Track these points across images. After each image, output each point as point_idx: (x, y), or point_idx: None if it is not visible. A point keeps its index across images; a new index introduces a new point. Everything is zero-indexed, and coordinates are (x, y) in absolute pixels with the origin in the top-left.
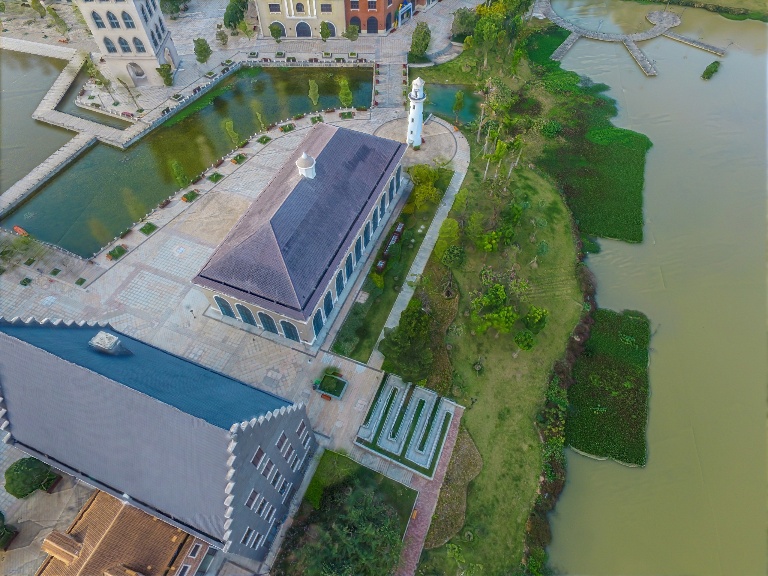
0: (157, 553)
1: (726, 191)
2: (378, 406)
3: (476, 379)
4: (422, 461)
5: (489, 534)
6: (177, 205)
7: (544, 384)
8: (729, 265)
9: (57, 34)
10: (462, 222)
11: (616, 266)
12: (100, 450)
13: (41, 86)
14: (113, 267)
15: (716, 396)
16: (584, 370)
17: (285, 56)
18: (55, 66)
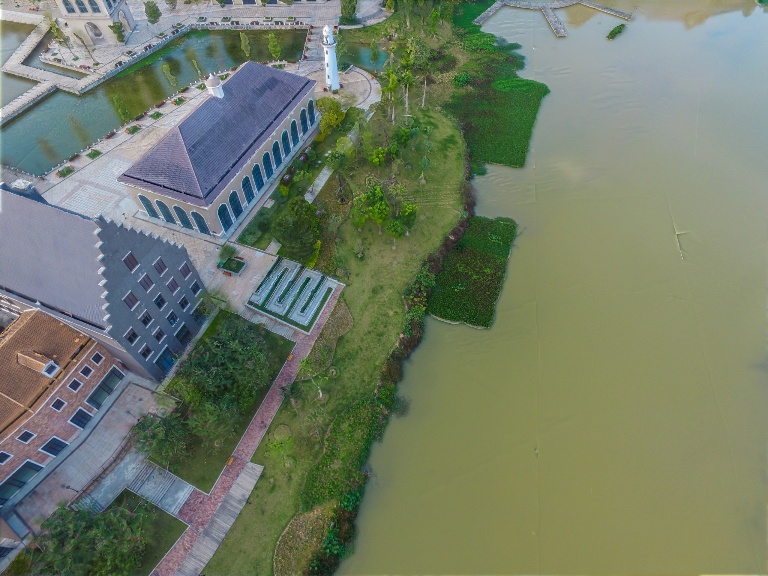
0: (62, 348)
1: (607, 127)
2: (270, 280)
3: (358, 264)
4: (302, 321)
5: (350, 371)
6: (120, 136)
7: (416, 269)
8: (595, 183)
9: (28, 4)
10: (359, 144)
11: (497, 185)
12: (15, 262)
13: (11, 46)
14: (61, 182)
15: (561, 279)
16: (453, 260)
17: (230, 20)
18: (25, 30)
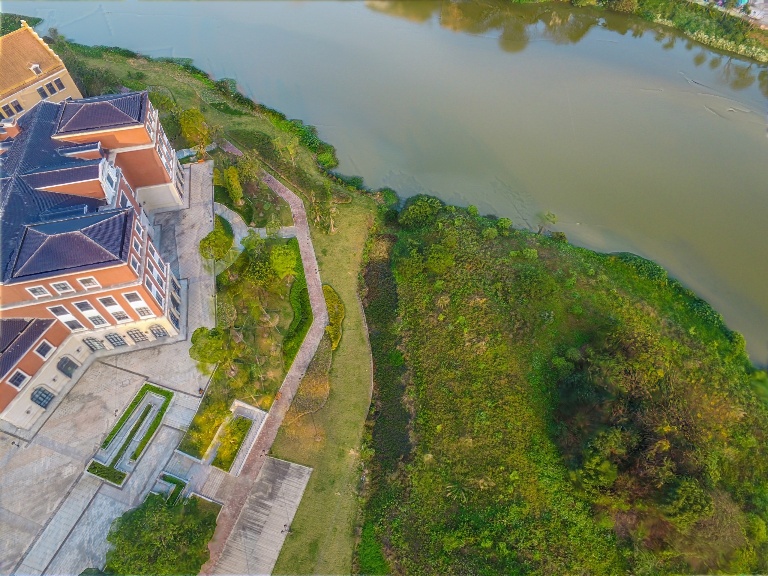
0: None
1: None
2: None
3: None
4: None
5: None
6: None
7: None
8: None
9: None
10: None
11: None
12: None
13: None
14: None
15: (29, 1)
16: None
17: None
18: None
